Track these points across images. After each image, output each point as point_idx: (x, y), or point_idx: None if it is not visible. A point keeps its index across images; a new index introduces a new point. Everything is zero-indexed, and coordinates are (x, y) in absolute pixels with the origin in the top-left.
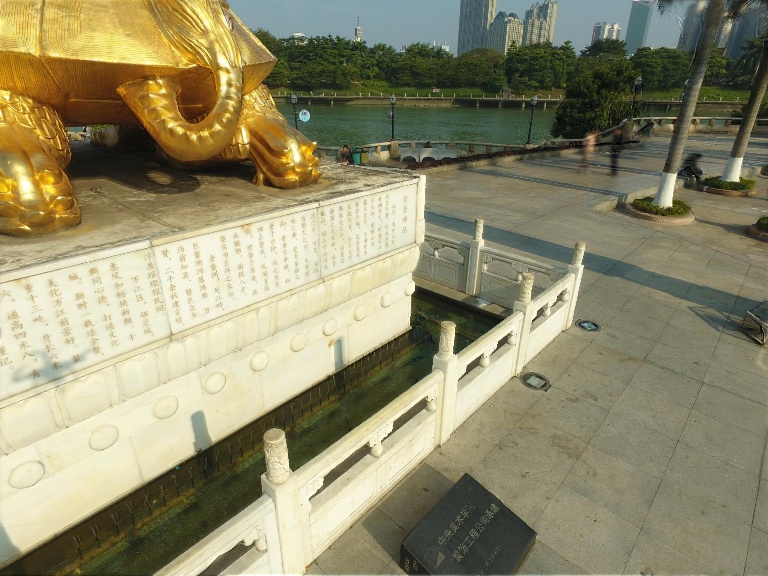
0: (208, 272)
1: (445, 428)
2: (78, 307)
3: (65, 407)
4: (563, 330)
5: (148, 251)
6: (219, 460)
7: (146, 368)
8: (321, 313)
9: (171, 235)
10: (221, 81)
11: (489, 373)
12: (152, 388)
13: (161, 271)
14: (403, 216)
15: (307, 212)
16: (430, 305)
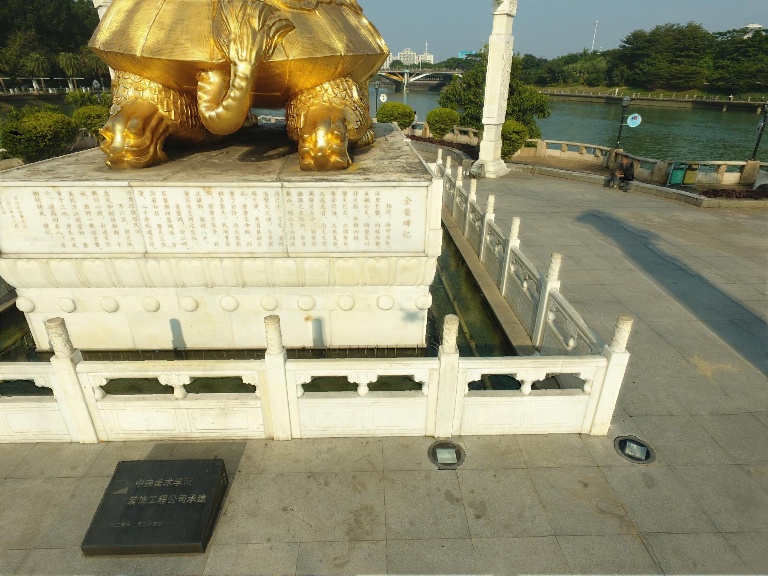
0: (175, 216)
1: (278, 424)
2: (86, 213)
3: (84, 274)
4: (582, 432)
5: (129, 189)
6: None
7: (132, 270)
8: (296, 286)
9: (146, 181)
10: (232, 72)
11: (367, 405)
12: (142, 287)
13: (139, 205)
14: (405, 219)
15: (270, 189)
16: (498, 340)
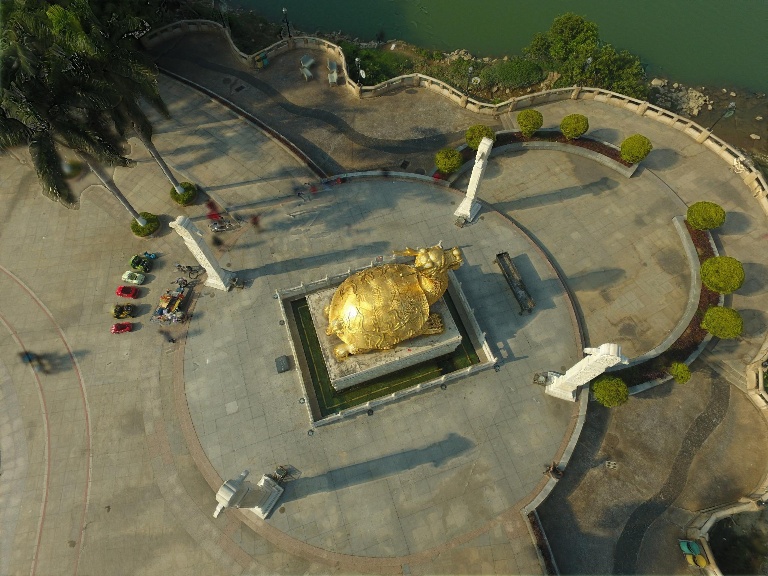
0: None
1: None
2: None
3: None
4: None
5: None
6: (317, 341)
7: None
8: None
9: None
10: None
11: None
12: None
13: None
14: None
15: None
16: None
